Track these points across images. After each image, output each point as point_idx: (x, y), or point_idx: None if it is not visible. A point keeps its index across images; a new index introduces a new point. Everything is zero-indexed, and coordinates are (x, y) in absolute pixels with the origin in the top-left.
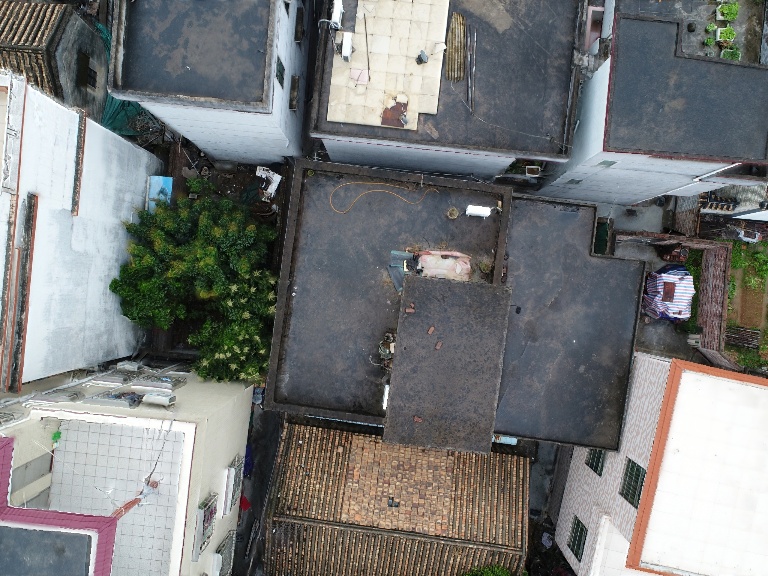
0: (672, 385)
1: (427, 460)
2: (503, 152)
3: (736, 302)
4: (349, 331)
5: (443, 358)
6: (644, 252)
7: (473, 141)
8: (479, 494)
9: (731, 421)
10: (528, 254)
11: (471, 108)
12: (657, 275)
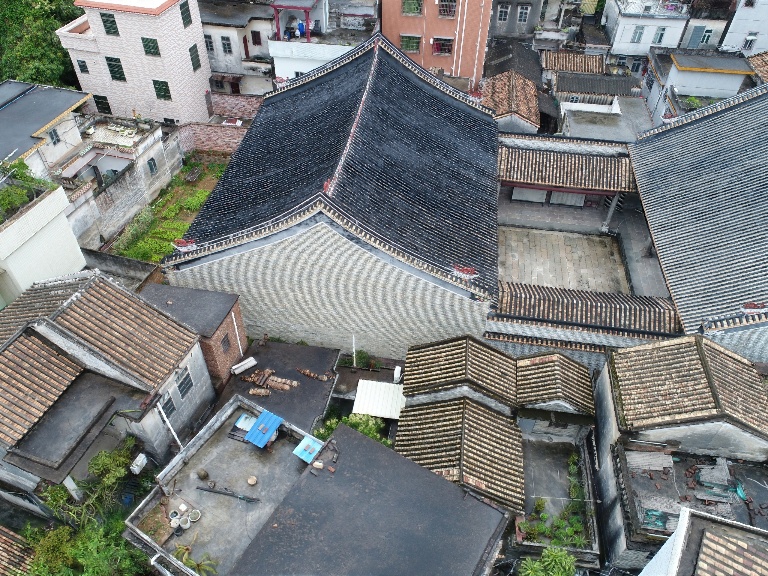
0: None
1: None
2: None
3: None
4: None
5: None
6: None
7: None
8: None
9: None
10: None
11: None
12: None
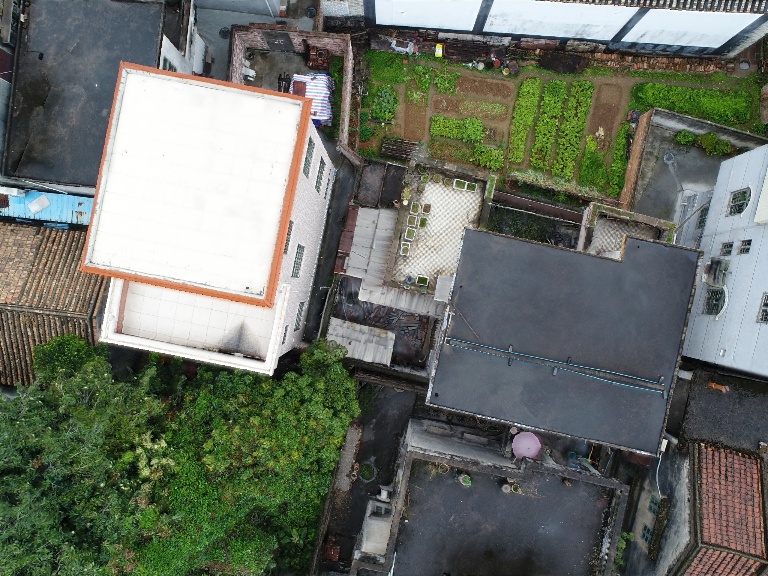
0: (117, 86)
1: (14, 239)
2: None
3: (400, 117)
4: None
5: None
6: (292, 62)
7: None
8: (60, 268)
9: (177, 121)
10: (49, 0)
11: None
12: (292, 77)
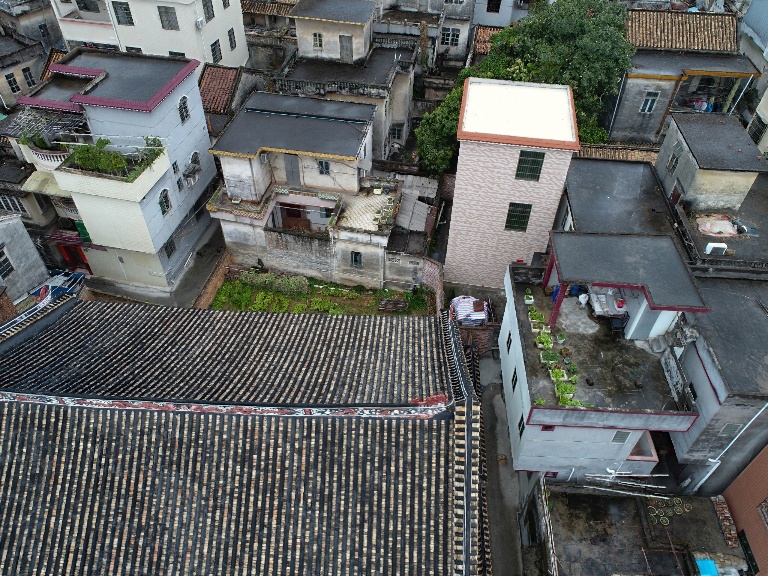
0: None
1: None
2: (725, 267)
3: None
4: (760, 201)
5: (724, 142)
6: None
7: (746, 285)
8: None
9: None
10: None
11: (761, 303)
12: None
